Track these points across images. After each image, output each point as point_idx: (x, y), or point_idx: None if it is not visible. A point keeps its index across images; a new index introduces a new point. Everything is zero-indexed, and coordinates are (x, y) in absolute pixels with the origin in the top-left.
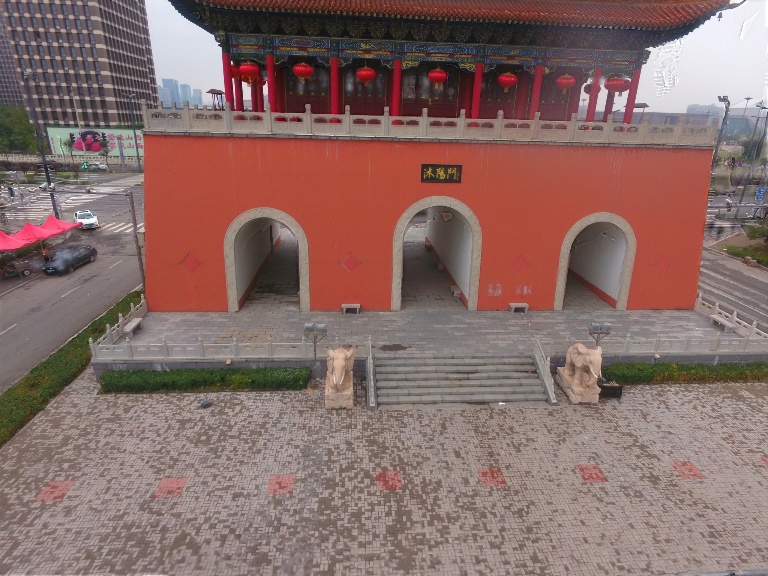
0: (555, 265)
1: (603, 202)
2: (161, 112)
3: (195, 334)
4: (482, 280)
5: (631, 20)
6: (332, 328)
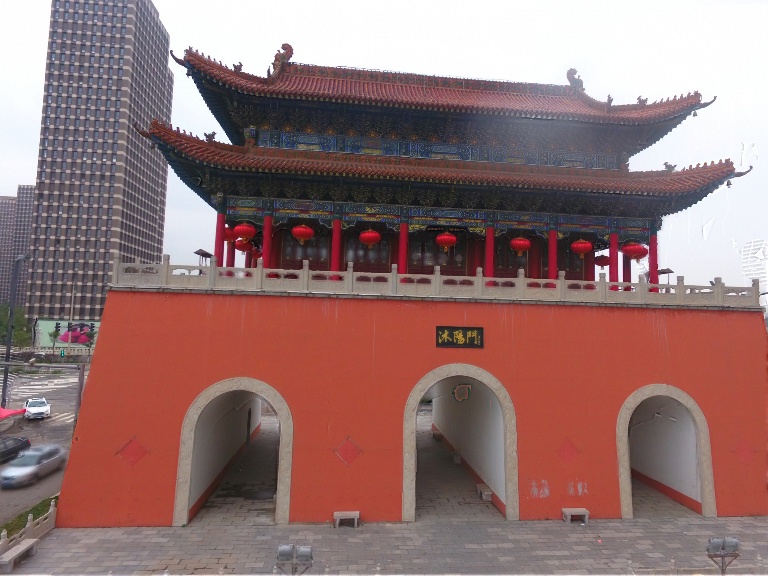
0: (612, 453)
1: (654, 371)
2: (135, 267)
3: (111, 565)
4: (521, 474)
5: (641, 187)
6: (319, 551)
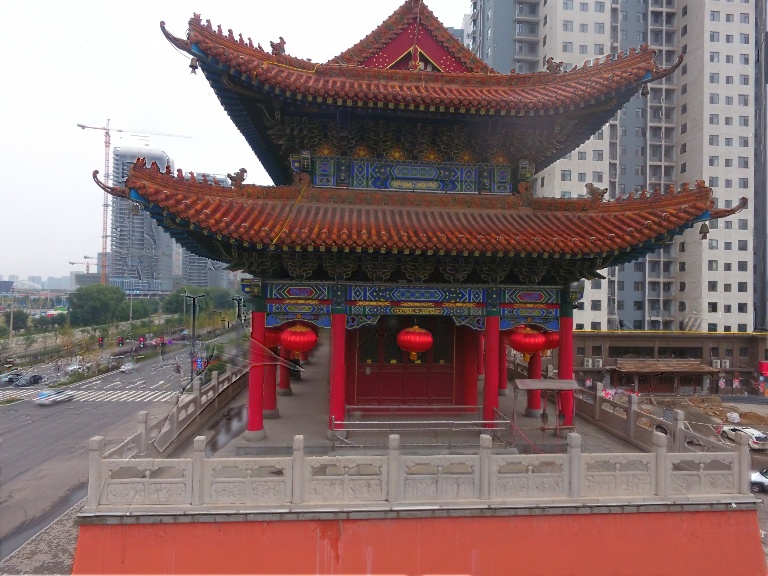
0: None
1: None
2: (716, 447)
3: None
4: None
5: None
6: None
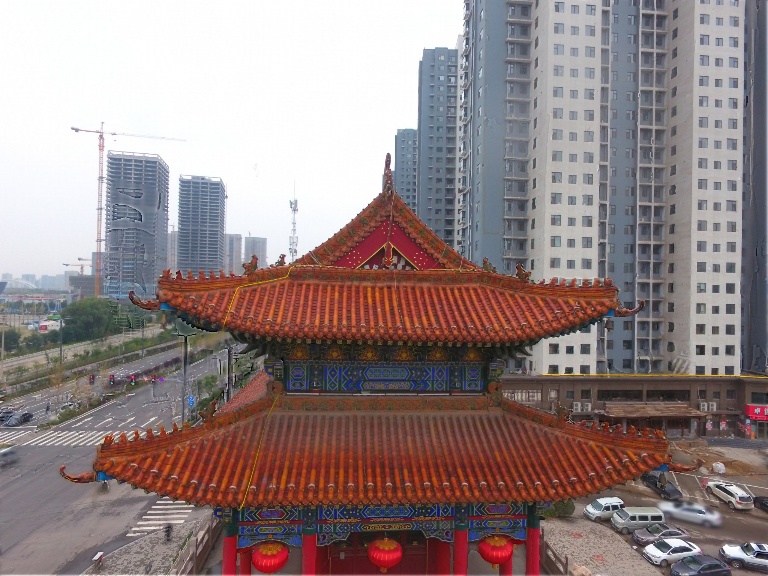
0: None
1: None
2: None
3: None
4: None
5: None
6: None
